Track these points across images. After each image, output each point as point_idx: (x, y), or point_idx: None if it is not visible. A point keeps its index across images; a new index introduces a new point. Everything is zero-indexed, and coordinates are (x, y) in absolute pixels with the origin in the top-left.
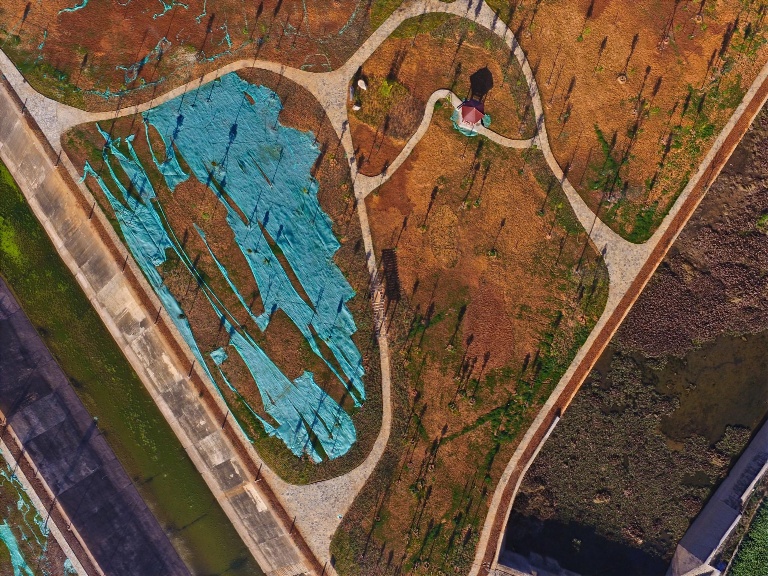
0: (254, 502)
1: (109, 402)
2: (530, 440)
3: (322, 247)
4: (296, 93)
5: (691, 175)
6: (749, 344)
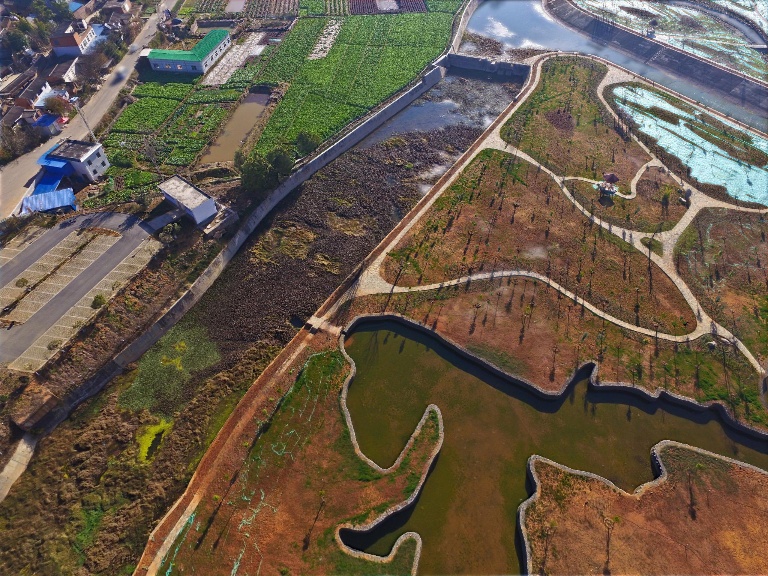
0: None
1: (741, 112)
2: (527, 93)
3: None
4: (722, 198)
5: None
6: None
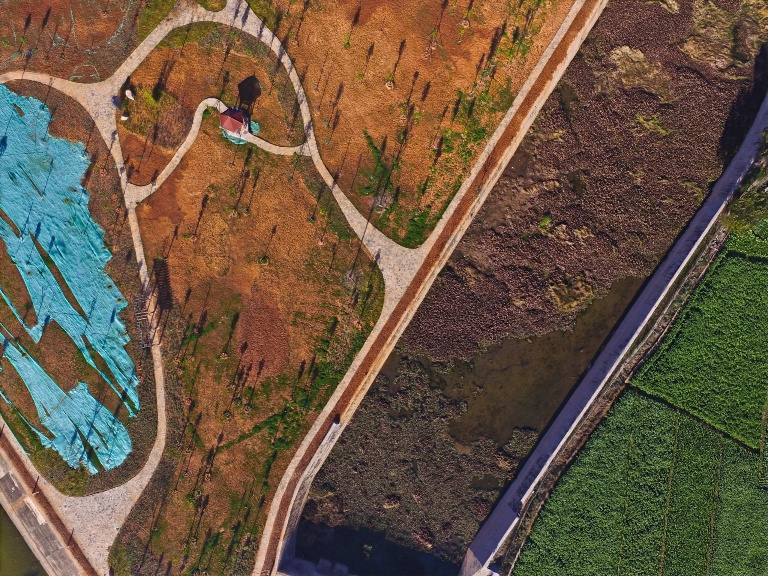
0: (34, 515)
1: None
2: (307, 447)
3: (94, 257)
4: (65, 104)
5: (463, 179)
6: (535, 346)
